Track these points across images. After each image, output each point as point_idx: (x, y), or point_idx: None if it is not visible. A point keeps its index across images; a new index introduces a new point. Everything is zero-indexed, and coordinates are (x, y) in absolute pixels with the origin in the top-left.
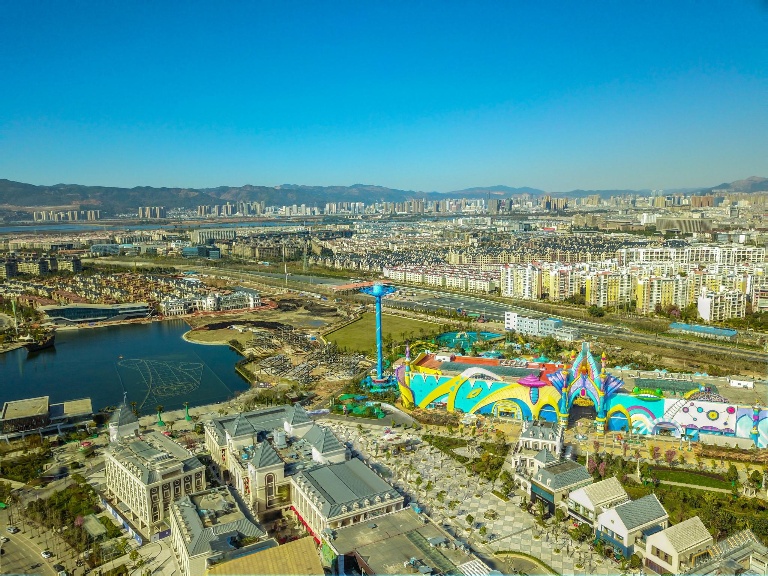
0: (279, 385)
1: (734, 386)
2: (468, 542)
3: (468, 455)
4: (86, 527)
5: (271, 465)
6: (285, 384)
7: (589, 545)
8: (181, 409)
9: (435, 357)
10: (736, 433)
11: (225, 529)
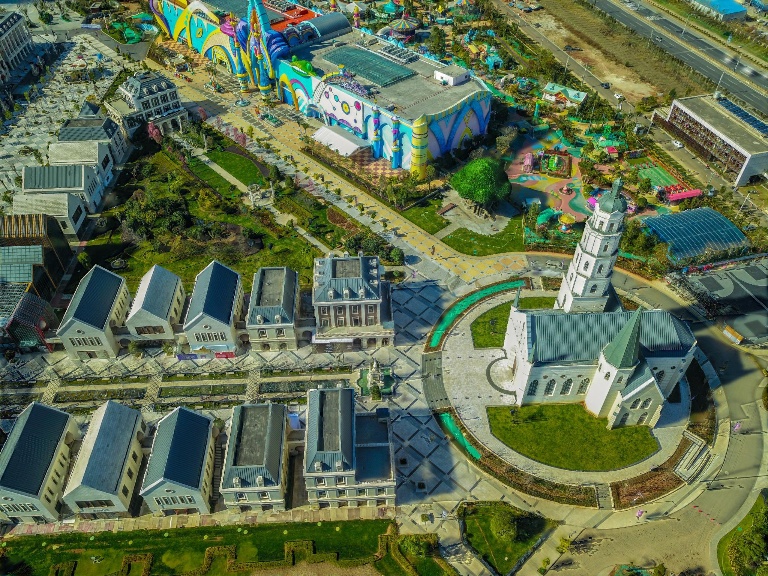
0: None
1: (437, 79)
2: None
3: None
4: None
5: None
6: None
7: None
8: (10, 3)
9: None
10: (367, 135)
11: None
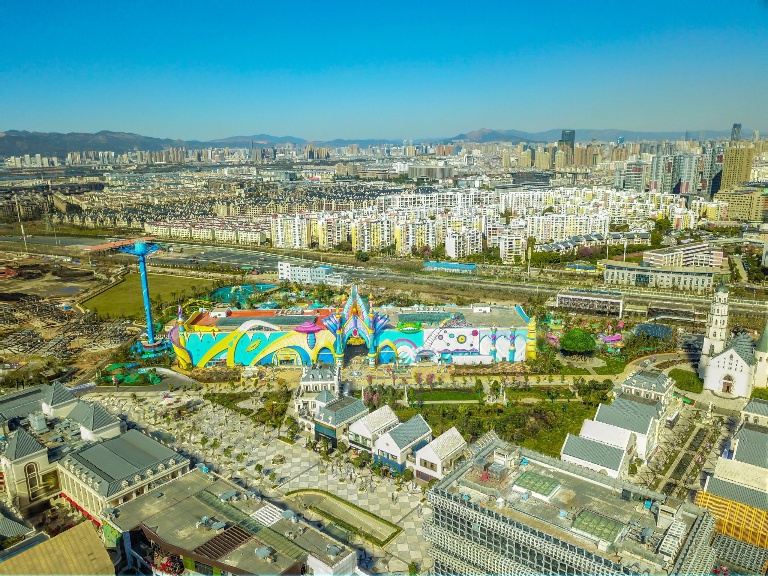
0: (30, 364)
1: (476, 312)
2: (259, 490)
3: (252, 407)
4: None
5: (30, 454)
6: (38, 362)
7: (369, 469)
8: None
9: (210, 314)
10: (480, 352)
11: None
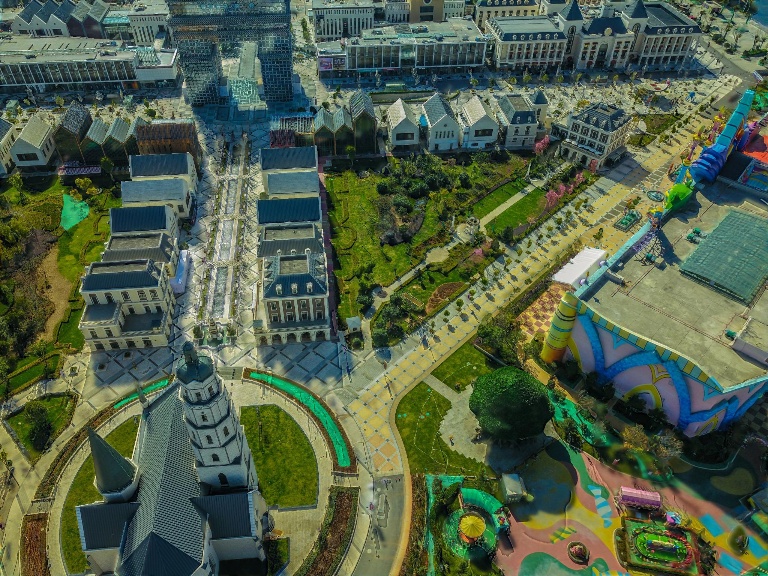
0: None
1: None
2: None
3: None
4: None
5: (546, 0)
6: None
7: None
8: None
9: None
10: None
11: None
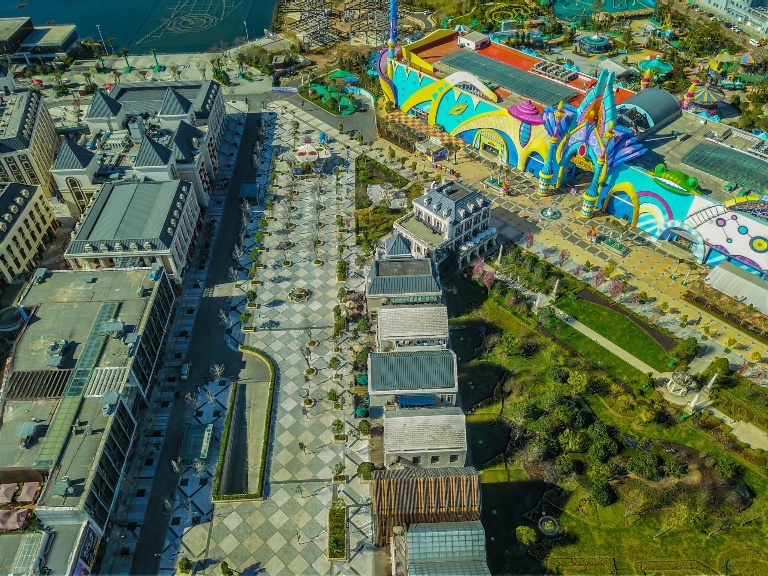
0: (283, 41)
1: None
2: (221, 324)
3: (376, 199)
4: None
5: (69, 169)
6: (290, 41)
7: (353, 379)
8: (166, 54)
9: (459, 39)
10: None
11: None
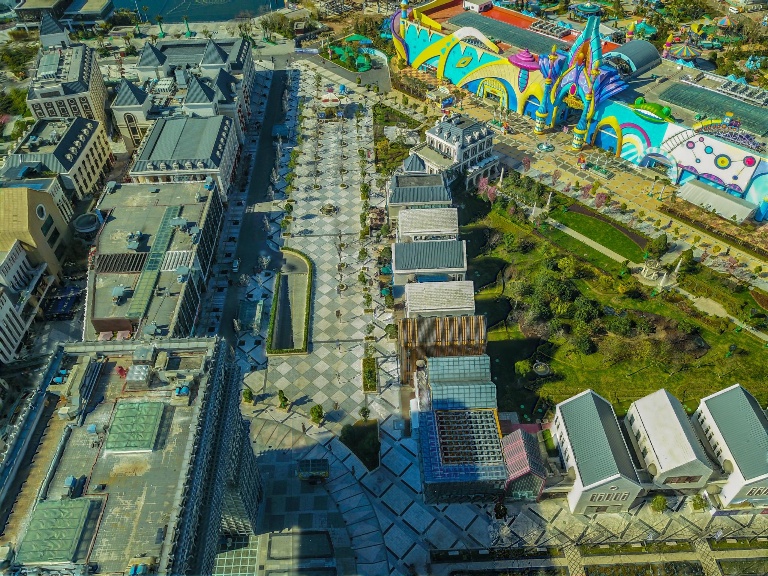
0: (302, 10)
1: None
2: (264, 230)
3: (392, 137)
4: (6, 126)
5: (127, 105)
6: (309, 10)
7: (378, 270)
8: (195, 22)
9: (464, 3)
10: (747, 194)
11: (31, 159)
